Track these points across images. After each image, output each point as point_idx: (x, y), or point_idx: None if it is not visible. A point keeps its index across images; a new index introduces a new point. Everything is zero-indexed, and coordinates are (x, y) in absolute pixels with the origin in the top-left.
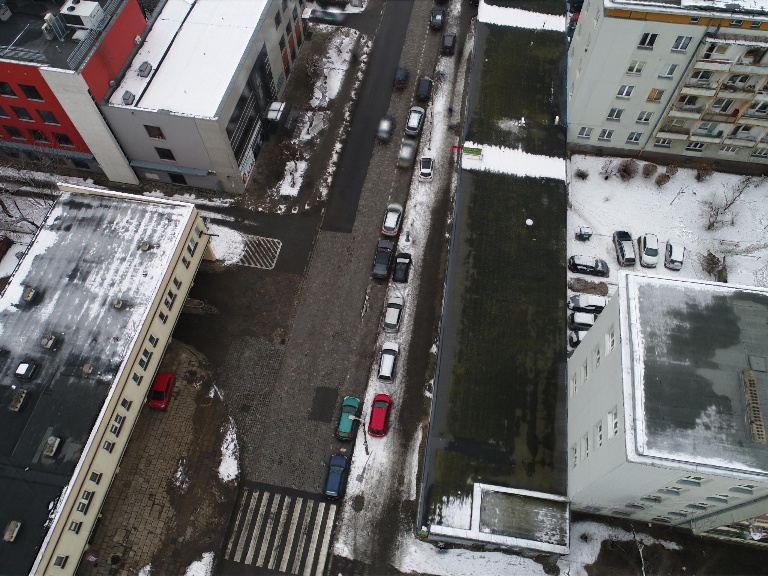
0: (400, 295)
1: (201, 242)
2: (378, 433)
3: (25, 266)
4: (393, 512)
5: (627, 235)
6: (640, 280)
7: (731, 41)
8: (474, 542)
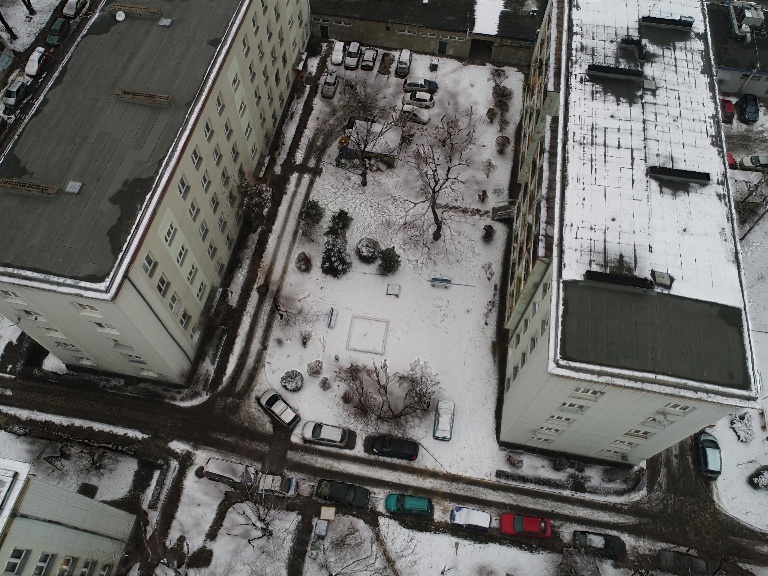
0: None
1: None
2: None
3: None
4: None
5: (432, 86)
6: None
7: (555, 4)
8: None
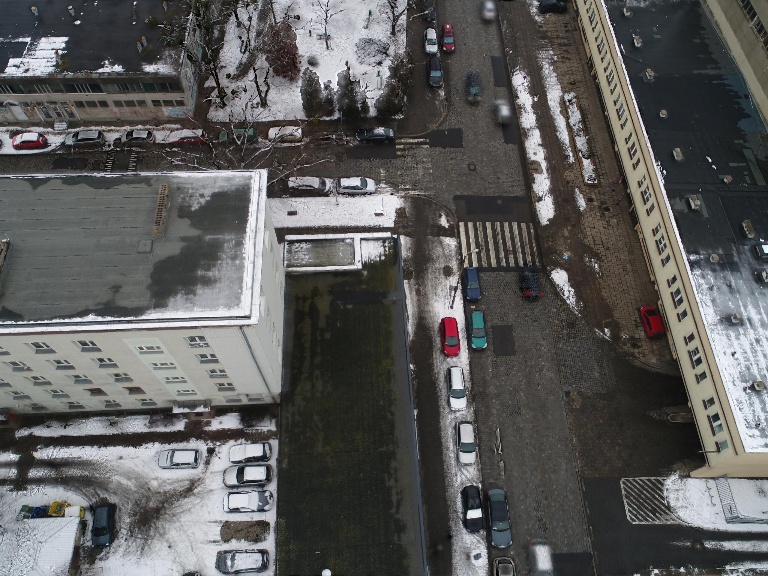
0: (465, 473)
1: (712, 445)
2: None
3: None
4: (419, 270)
5: None
6: (238, 311)
7: None
8: None
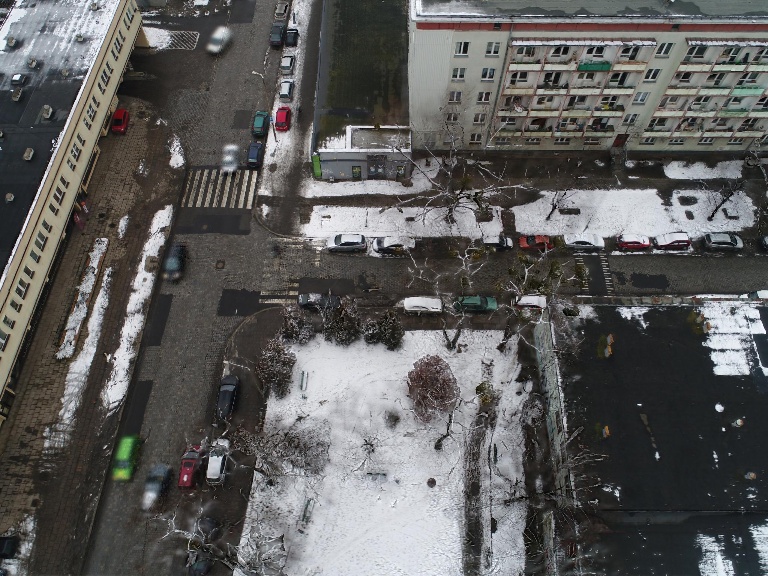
0: None
1: (136, 18)
2: (282, 126)
3: (5, 29)
4: (298, 169)
5: None
6: None
7: None
8: (351, 164)
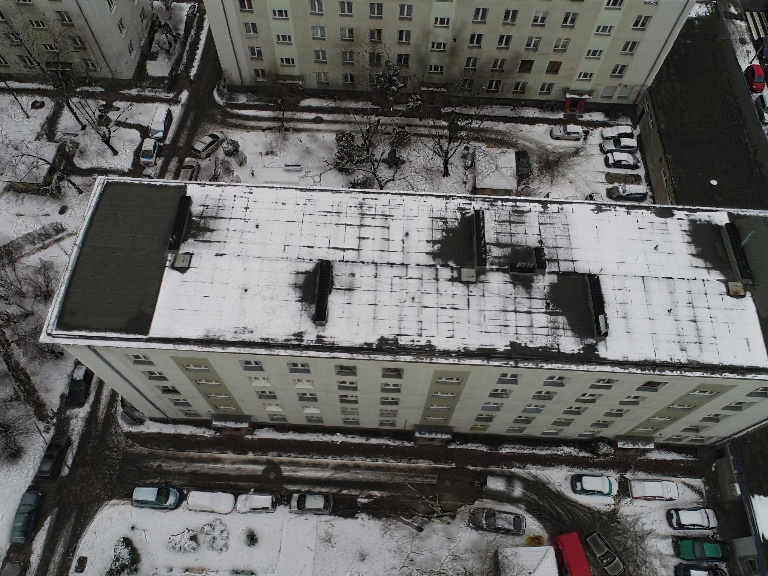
0: None
1: None
2: None
3: None
4: None
5: None
6: None
7: None
8: None
